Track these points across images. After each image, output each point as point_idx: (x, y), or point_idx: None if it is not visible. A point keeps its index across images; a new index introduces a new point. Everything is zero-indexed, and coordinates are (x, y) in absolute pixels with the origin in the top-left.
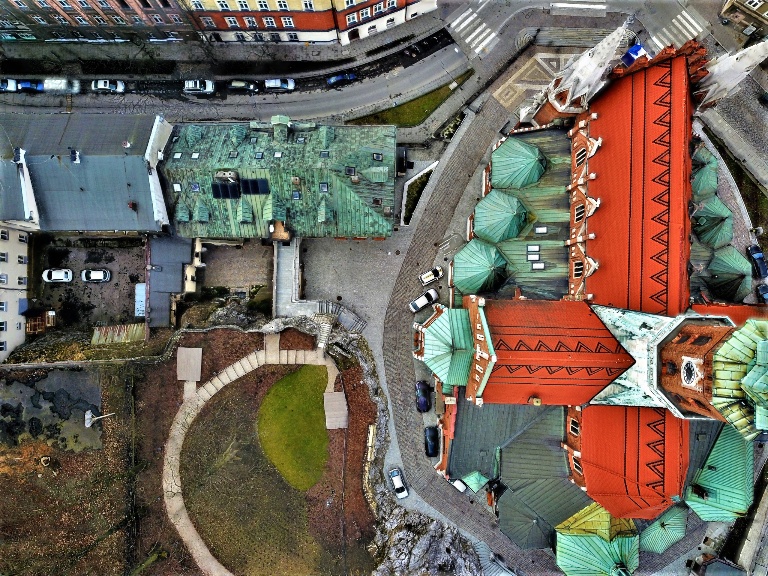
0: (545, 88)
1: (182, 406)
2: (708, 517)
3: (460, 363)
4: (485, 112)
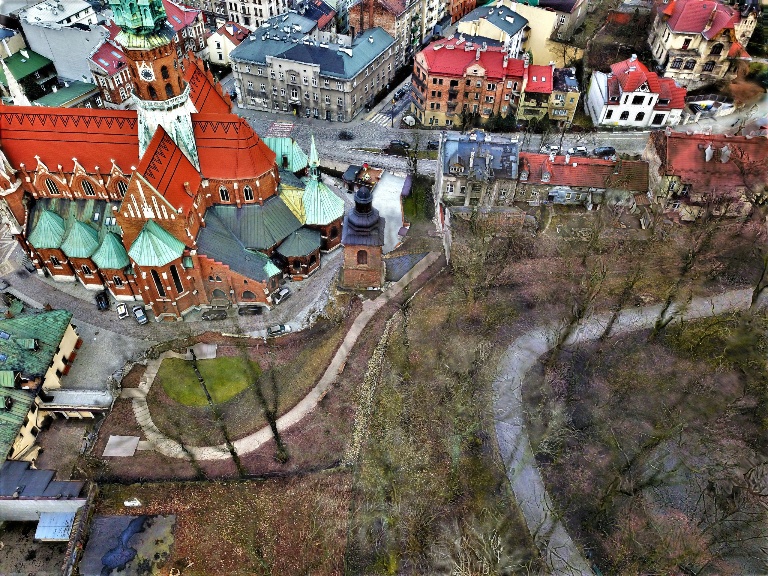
0: (3, 220)
1: (158, 451)
2: (303, 163)
3: (161, 235)
4: (11, 281)
